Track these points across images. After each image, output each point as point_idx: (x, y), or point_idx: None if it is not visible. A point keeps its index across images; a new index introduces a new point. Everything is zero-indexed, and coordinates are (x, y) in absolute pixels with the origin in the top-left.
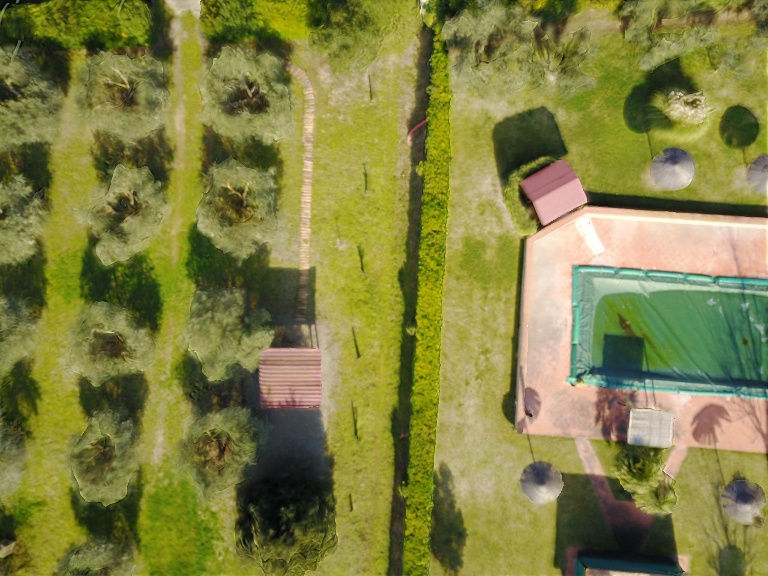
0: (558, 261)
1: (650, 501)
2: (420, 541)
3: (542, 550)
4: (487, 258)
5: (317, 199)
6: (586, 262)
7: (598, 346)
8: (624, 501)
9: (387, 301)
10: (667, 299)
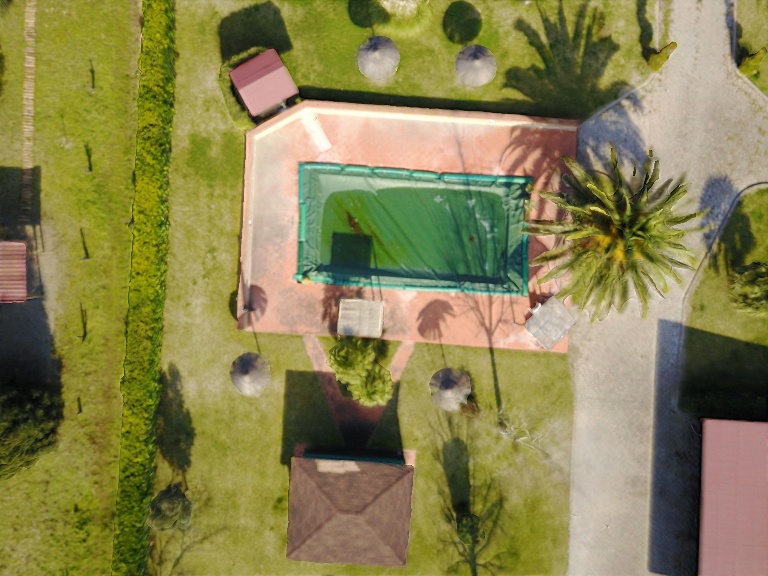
0: (285, 158)
1: (363, 392)
2: (136, 438)
3: (268, 447)
4: (213, 155)
5: (41, 96)
6: (313, 159)
7: (326, 243)
8: (351, 397)
9: (120, 203)
10: (395, 196)
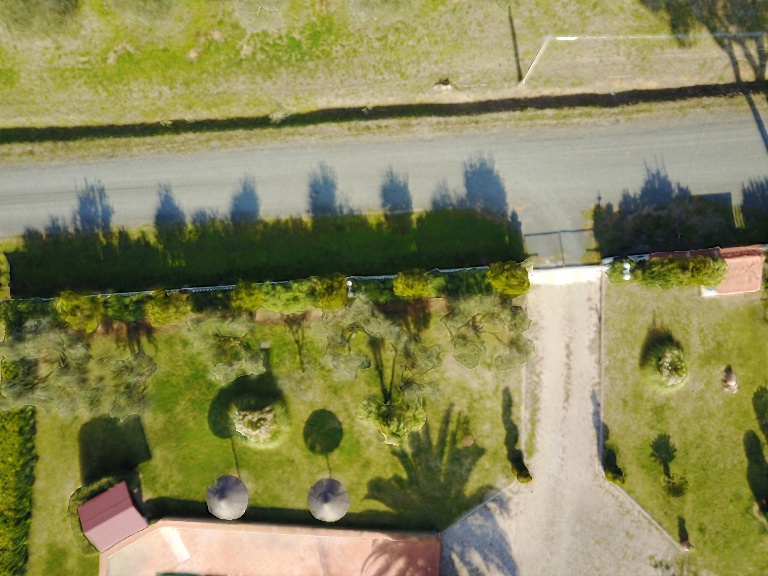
0: (143, 569)
1: None
2: None
3: None
4: (68, 568)
5: None
6: (171, 570)
7: None
8: None
9: None
10: None
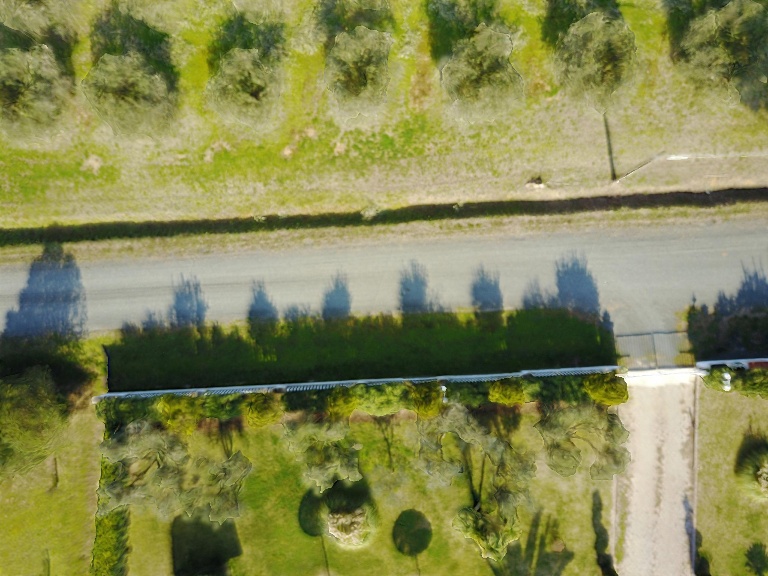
0: None
1: None
2: None
3: None
4: None
5: None
6: None
7: None
8: None
9: None
10: None
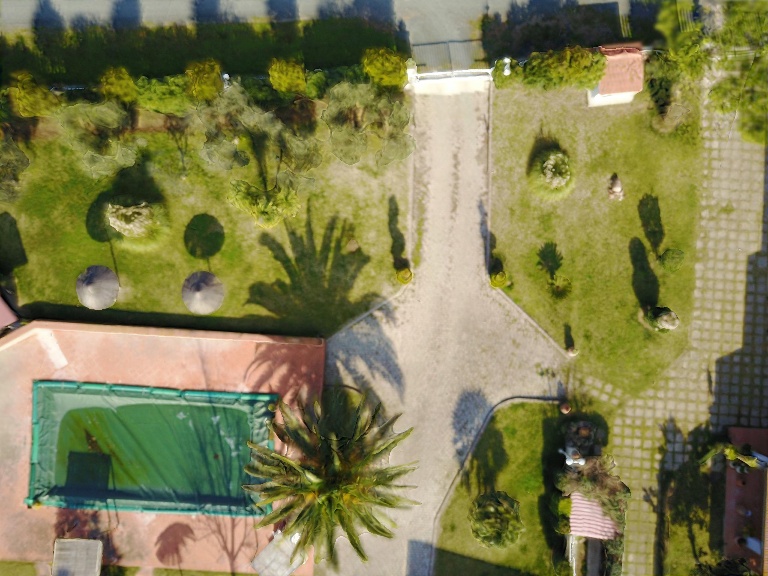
0: (19, 375)
1: None
2: None
3: None
4: None
5: None
6: (48, 376)
7: (61, 464)
8: None
9: None
10: (136, 413)
